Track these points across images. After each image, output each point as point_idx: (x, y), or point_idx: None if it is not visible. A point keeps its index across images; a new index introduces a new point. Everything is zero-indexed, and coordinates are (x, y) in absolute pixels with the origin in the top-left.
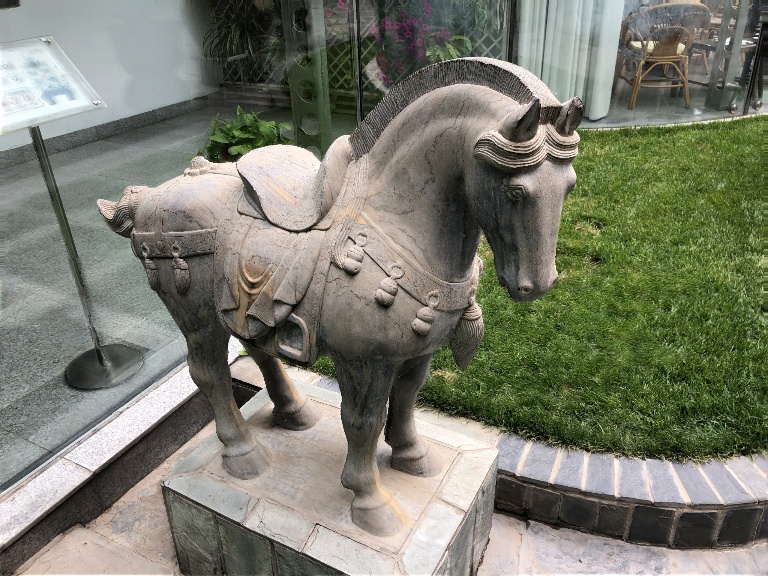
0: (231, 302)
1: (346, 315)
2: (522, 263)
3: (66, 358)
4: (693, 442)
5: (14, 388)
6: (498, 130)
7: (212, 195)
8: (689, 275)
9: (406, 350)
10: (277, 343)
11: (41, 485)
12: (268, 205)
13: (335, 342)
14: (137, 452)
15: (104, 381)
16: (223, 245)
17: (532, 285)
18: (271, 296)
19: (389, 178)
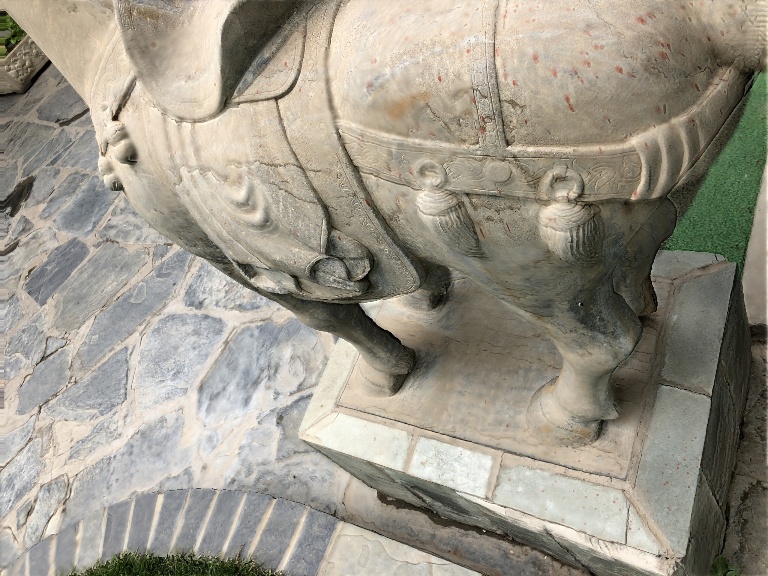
0: None
1: None
2: None
3: None
4: None
5: None
6: None
7: None
8: None
9: None
10: None
11: None
12: None
13: None
14: None
15: None
16: None
17: None
18: None
19: None
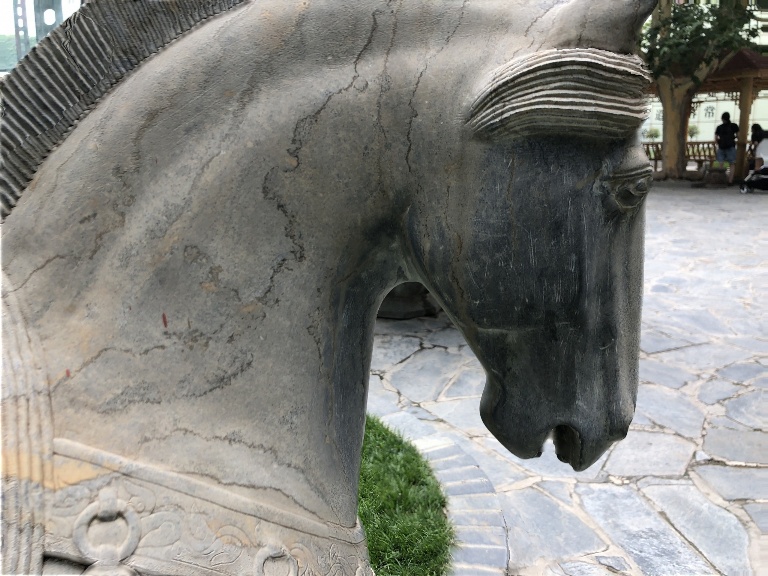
0: None
1: None
2: (623, 365)
3: None
4: None
5: None
6: (553, 45)
7: None
8: None
9: None
10: None
11: None
12: None
13: None
14: None
15: None
16: None
17: None
18: None
19: (131, 293)
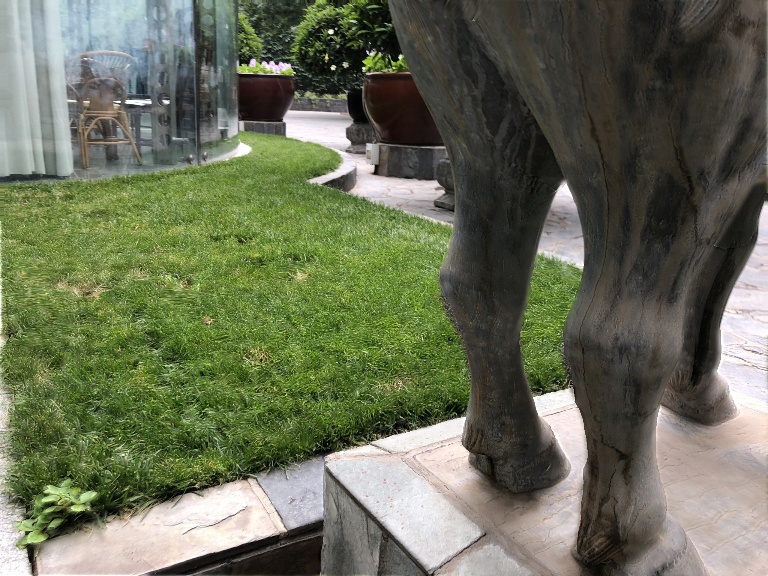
0: None
1: None
2: None
3: None
4: None
5: None
6: None
7: None
8: (390, 247)
9: None
10: None
11: None
12: None
13: None
14: None
15: None
16: None
17: None
18: None
19: None
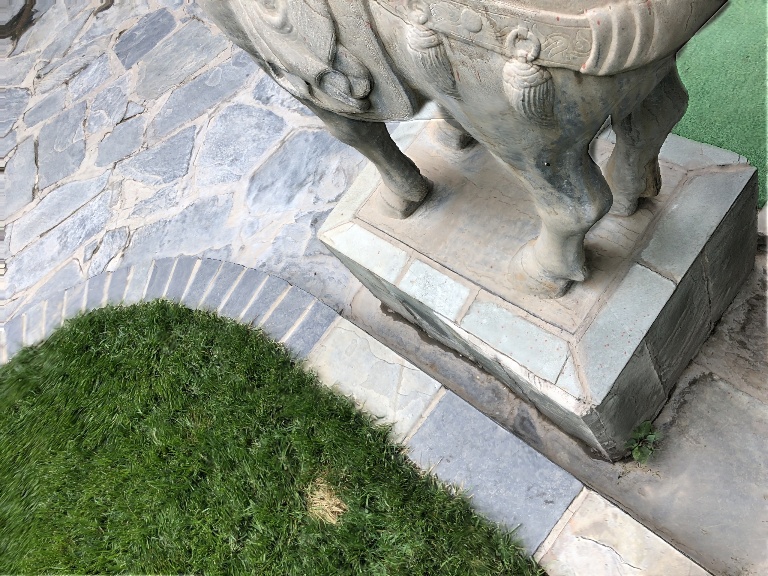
0: None
1: None
2: None
3: None
4: (145, 315)
5: None
6: None
7: None
8: None
9: None
10: None
11: None
12: None
13: None
14: None
15: None
16: None
17: None
18: None
19: None
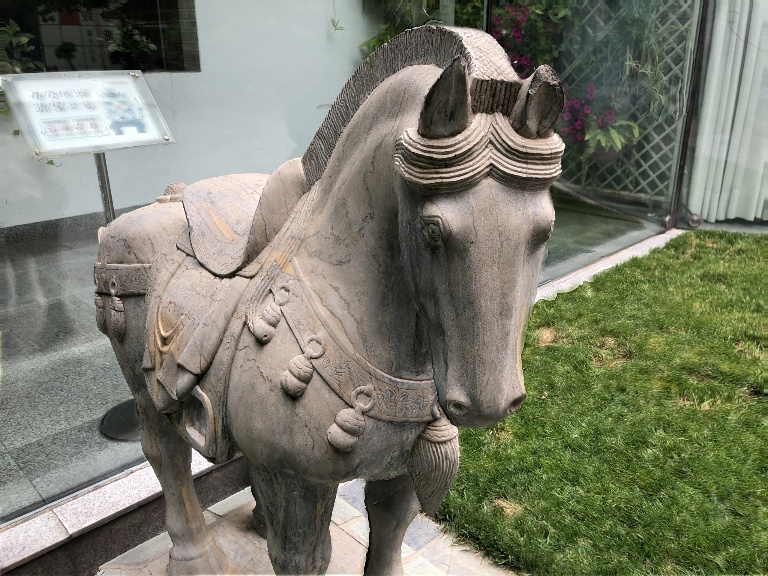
0: (149, 359)
1: (248, 400)
2: (451, 358)
3: (114, 401)
4: None
5: (52, 423)
6: None
7: (159, 223)
8: None
9: (321, 469)
10: (184, 423)
11: (14, 537)
12: (199, 239)
13: (238, 437)
14: (131, 522)
15: (135, 433)
16: (153, 285)
17: (468, 400)
18: (177, 358)
19: (329, 212)
